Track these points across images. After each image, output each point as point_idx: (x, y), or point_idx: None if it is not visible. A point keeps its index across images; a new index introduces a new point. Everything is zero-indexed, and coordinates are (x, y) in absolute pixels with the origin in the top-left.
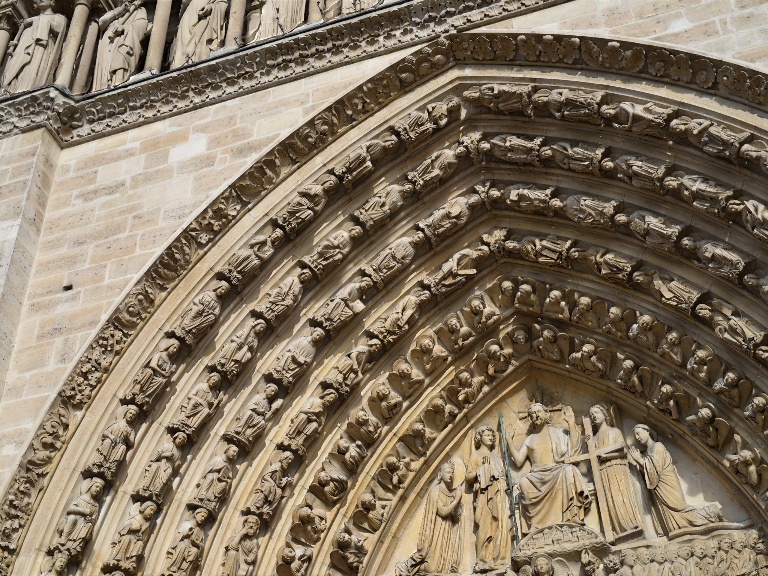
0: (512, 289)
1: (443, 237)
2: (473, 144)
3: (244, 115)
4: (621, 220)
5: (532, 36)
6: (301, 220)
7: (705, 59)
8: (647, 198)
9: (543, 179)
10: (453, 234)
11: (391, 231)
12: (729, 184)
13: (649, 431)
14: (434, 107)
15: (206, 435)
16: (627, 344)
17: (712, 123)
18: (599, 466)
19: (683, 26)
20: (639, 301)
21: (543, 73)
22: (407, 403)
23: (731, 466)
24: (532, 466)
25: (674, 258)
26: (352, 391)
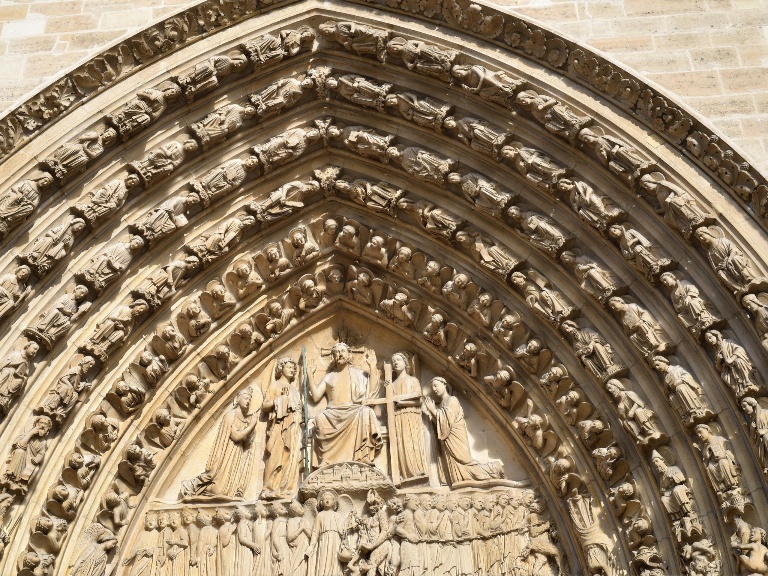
0: (335, 228)
1: (276, 165)
2: (321, 78)
3: (89, 4)
4: (454, 179)
5: None
6: (137, 123)
7: (560, 39)
8: (482, 162)
9: (384, 125)
10: (286, 164)
11: (225, 150)
12: (563, 163)
13: (446, 384)
14: (288, 34)
15: (6, 328)
16: (439, 299)
17: (557, 102)
18: (394, 411)
19: (544, 3)
20: (457, 259)
21: (401, 21)
22: (215, 324)
23: (519, 428)
24: (329, 403)
25: (498, 224)
26: (162, 305)
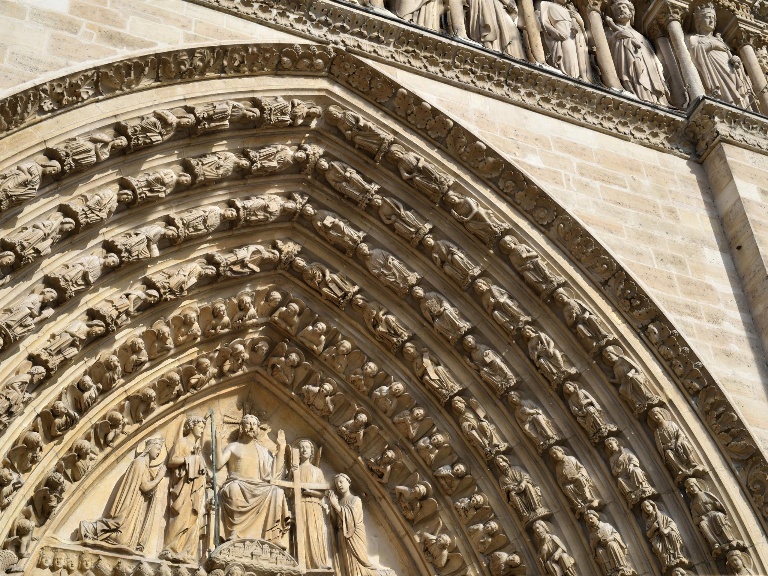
0: (279, 301)
1: None
2: (315, 156)
3: (116, 0)
4: (419, 293)
5: (413, 95)
6: (150, 141)
7: (553, 201)
8: (446, 285)
9: (358, 220)
10: (255, 226)
11: (208, 194)
12: (527, 310)
13: (350, 483)
14: (299, 104)
15: None
16: (364, 399)
17: (537, 255)
18: None
19: (537, 162)
20: (395, 367)
21: (405, 131)
22: (148, 365)
23: (422, 543)
24: (234, 473)
25: (446, 346)
26: None
